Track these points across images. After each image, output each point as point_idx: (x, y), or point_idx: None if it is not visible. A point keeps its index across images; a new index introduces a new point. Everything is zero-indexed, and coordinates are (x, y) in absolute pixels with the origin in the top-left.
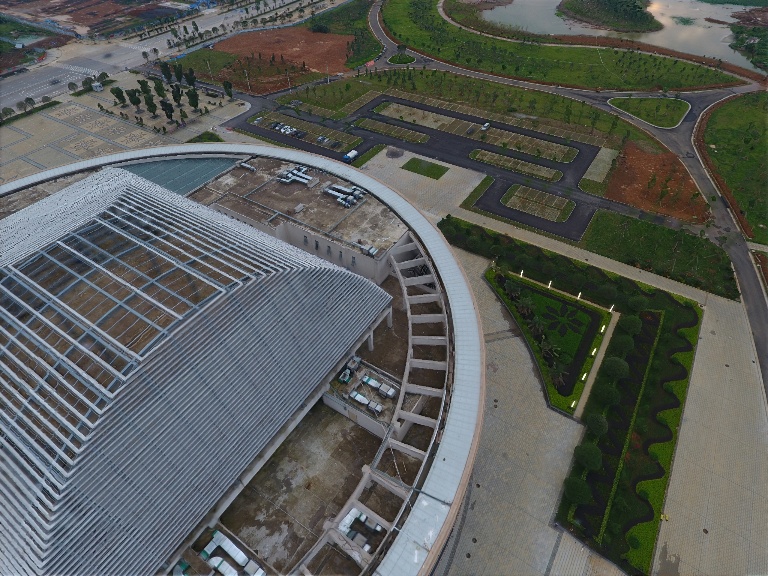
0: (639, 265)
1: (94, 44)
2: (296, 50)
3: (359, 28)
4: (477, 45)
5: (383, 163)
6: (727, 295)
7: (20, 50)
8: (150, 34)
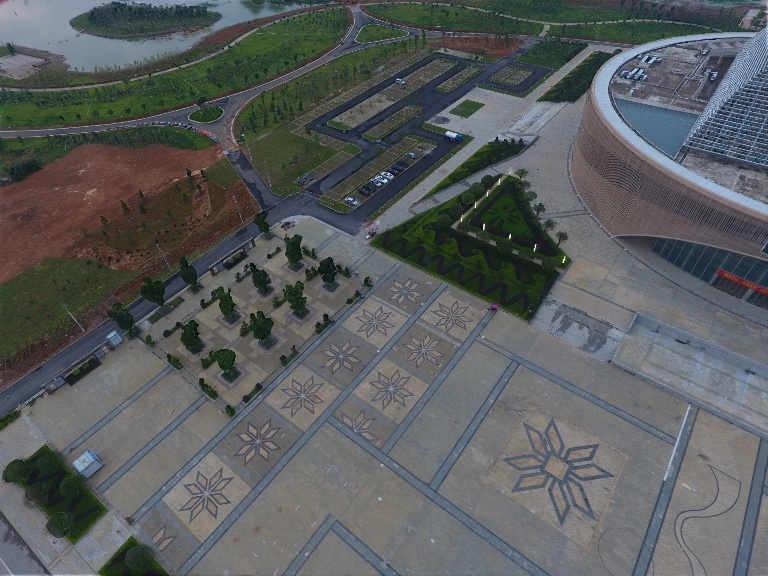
0: None
1: None
2: (97, 192)
3: None
4: (218, 69)
5: (459, 125)
6: (586, 45)
7: None
8: None
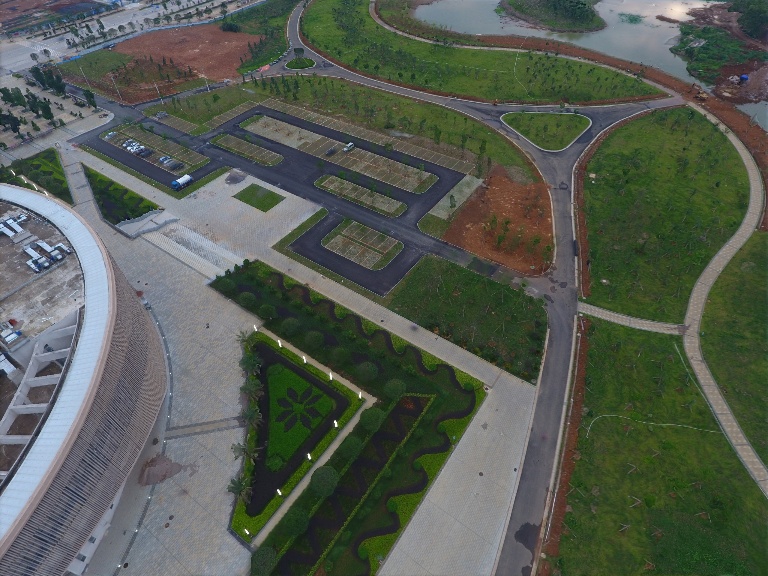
0: (437, 330)
1: None
2: (194, 52)
3: (273, 26)
4: (384, 48)
5: (216, 190)
6: (522, 375)
7: None
8: (56, 32)
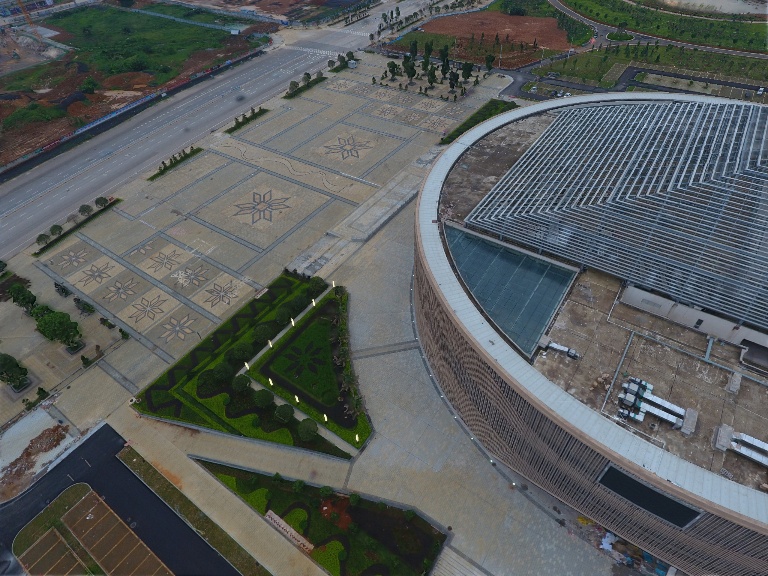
0: None
1: (305, 29)
2: (509, 31)
3: (553, 11)
4: (690, 22)
5: None
6: None
7: (239, 36)
8: (352, 20)
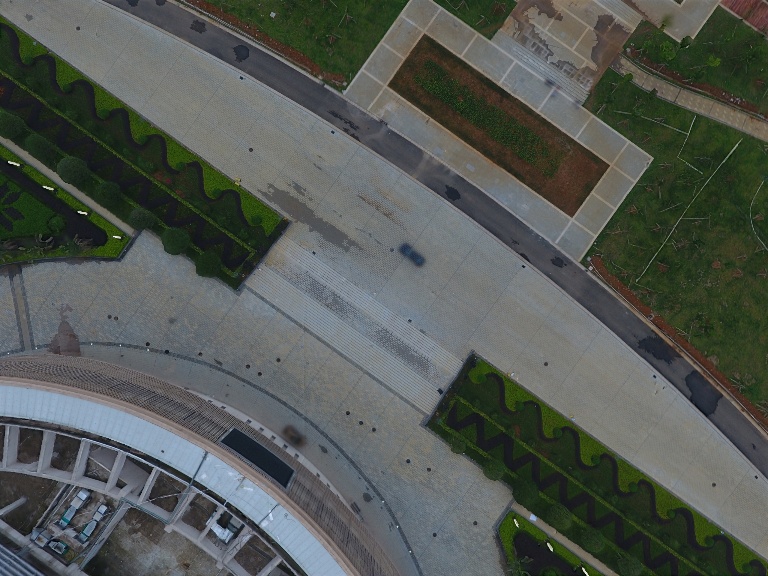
0: None
1: None
2: None
3: None
4: None
5: None
6: None
7: None
8: None
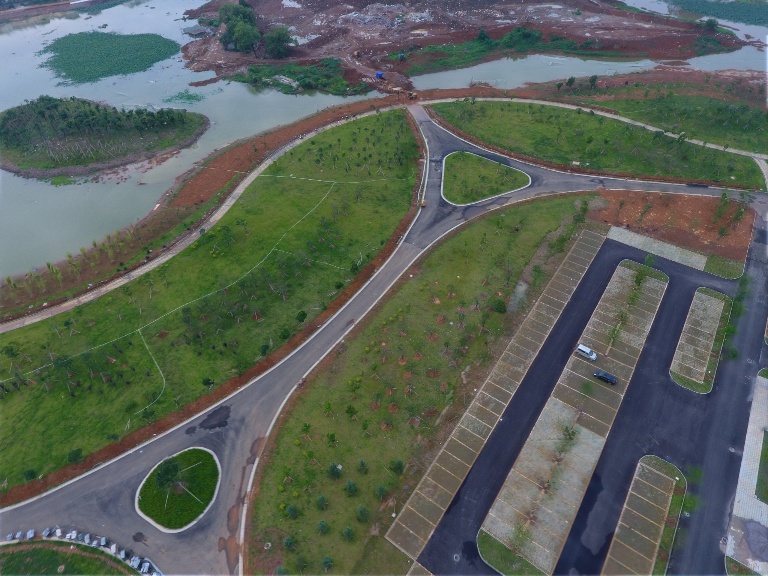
0: None
1: None
2: None
3: None
4: (204, 308)
5: None
6: None
7: None
8: None
